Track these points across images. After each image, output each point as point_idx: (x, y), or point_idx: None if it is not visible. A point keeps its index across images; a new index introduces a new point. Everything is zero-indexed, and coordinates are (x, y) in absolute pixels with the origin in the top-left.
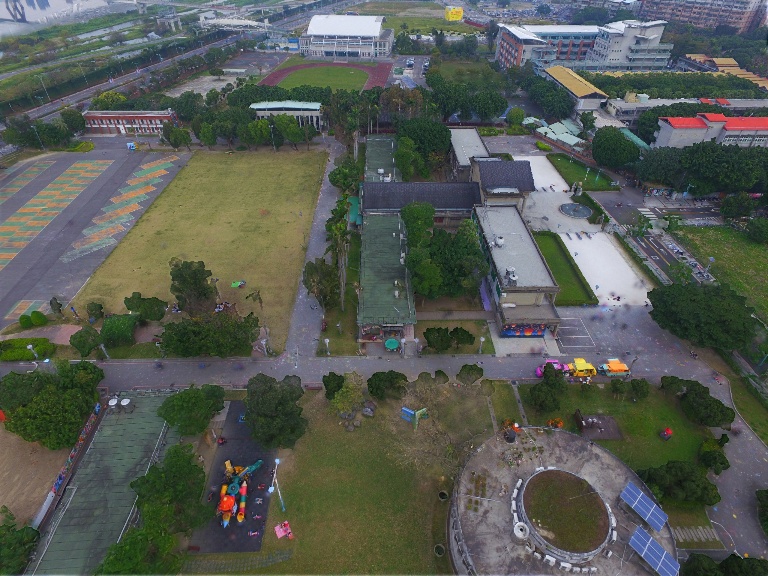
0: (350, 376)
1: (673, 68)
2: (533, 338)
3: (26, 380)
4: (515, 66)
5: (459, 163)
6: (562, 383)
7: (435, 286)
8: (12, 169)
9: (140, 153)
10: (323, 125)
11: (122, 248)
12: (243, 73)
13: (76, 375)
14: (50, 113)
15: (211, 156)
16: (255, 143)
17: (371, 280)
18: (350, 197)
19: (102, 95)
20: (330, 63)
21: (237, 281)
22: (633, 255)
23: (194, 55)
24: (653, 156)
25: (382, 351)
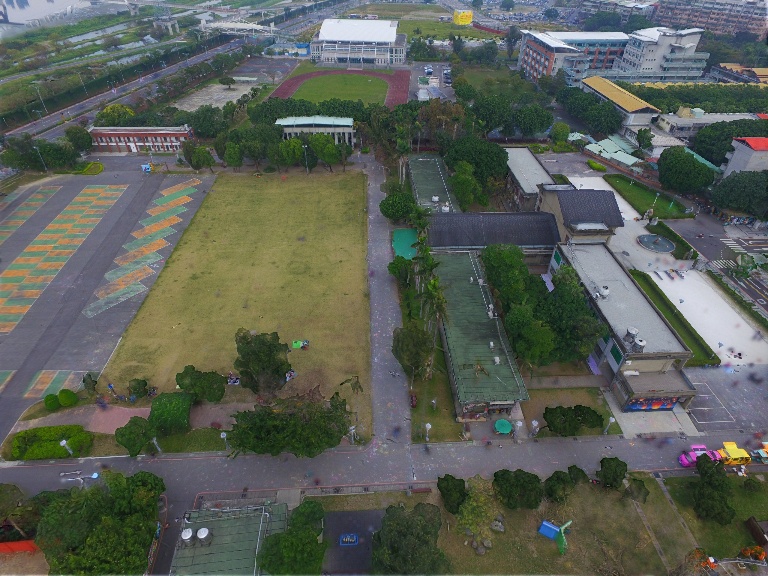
0: (479, 485)
1: (705, 77)
2: (661, 412)
3: (73, 509)
4: (546, 76)
5: (524, 190)
6: (728, 483)
7: (546, 352)
8: (13, 196)
9: (157, 176)
10: (356, 142)
11: (154, 297)
12: (254, 82)
13: (134, 494)
14: (49, 128)
15: (237, 179)
16: (286, 164)
17: (460, 340)
18: (404, 229)
19: (107, 108)
20: (344, 70)
21: (298, 340)
22: (738, 299)
23: (201, 62)
24: (734, 181)
25: (490, 434)
